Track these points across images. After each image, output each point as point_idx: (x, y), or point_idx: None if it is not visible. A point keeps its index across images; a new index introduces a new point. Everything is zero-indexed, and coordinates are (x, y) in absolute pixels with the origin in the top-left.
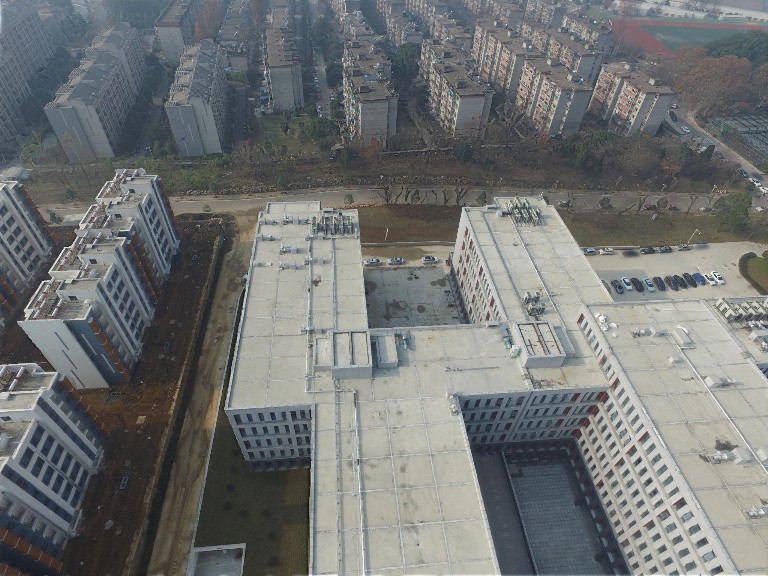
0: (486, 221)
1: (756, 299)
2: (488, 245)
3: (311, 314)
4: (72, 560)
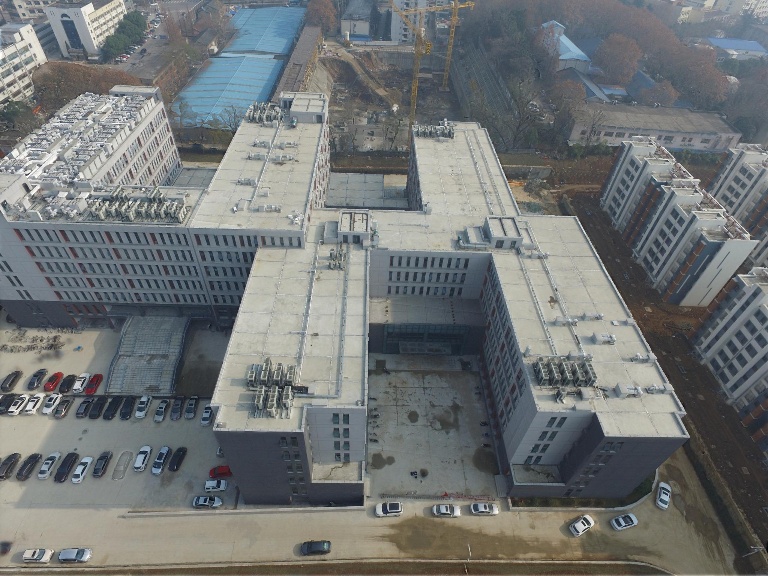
0: (338, 379)
1: (134, 224)
2: (352, 335)
3: (546, 271)
4: (624, 248)
